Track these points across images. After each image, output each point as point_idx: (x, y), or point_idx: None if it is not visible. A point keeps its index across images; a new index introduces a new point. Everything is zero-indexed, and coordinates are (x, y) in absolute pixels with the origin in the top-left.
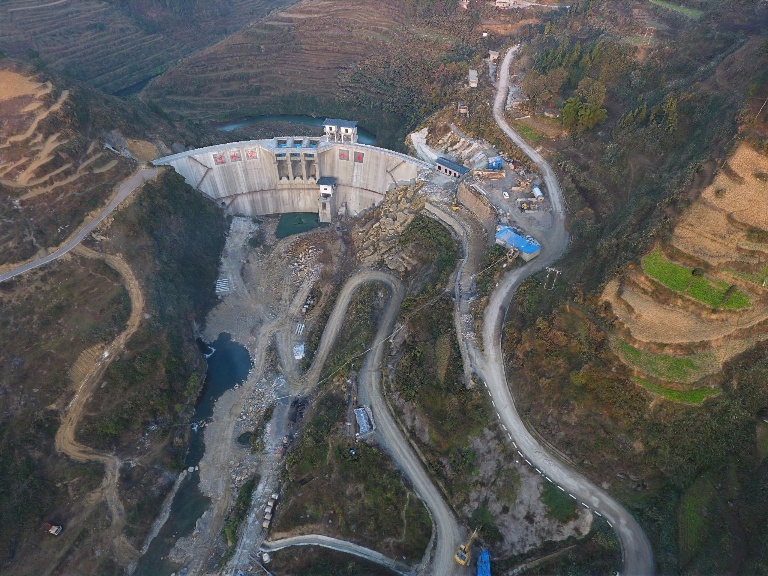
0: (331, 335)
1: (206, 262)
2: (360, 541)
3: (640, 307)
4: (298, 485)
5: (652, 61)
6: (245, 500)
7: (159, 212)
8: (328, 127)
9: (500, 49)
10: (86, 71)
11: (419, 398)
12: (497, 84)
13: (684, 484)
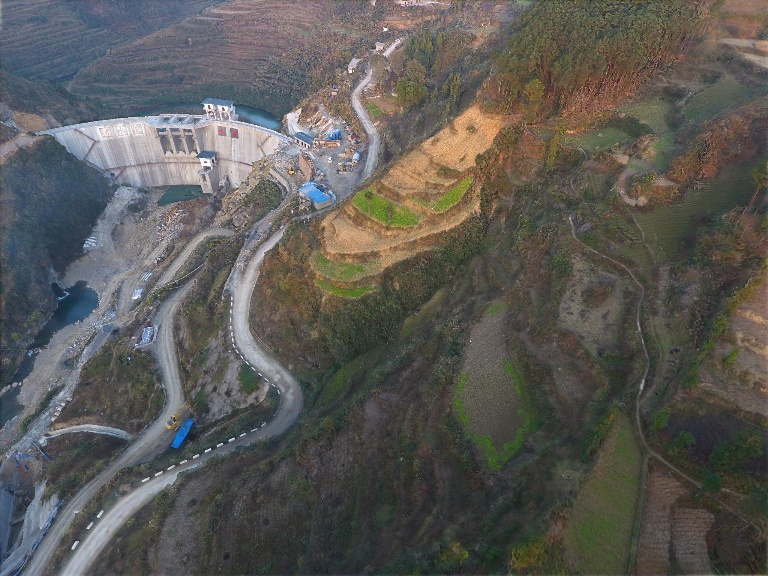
0: (166, 279)
1: (77, 221)
2: (117, 425)
3: (341, 228)
4: (83, 386)
5: (482, 47)
6: (43, 402)
7: (30, 174)
8: (207, 105)
9: (387, 41)
10: (22, 60)
11: (189, 314)
12: (369, 70)
13: (344, 362)
